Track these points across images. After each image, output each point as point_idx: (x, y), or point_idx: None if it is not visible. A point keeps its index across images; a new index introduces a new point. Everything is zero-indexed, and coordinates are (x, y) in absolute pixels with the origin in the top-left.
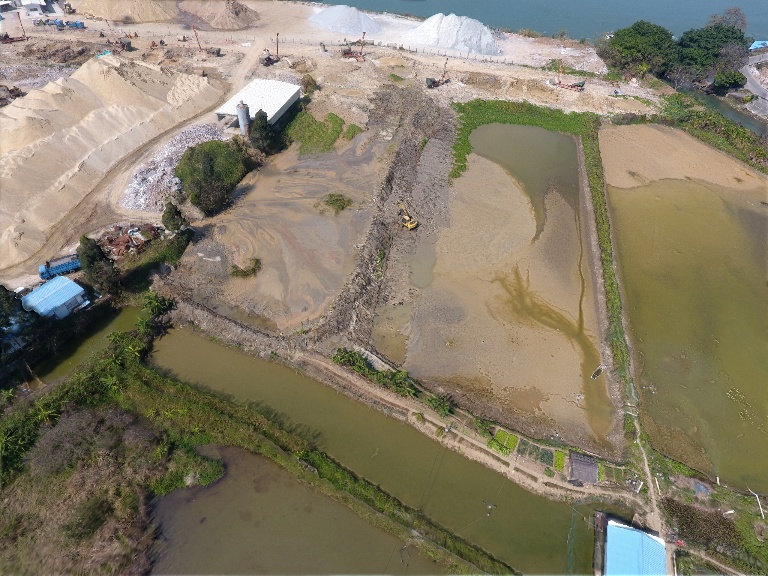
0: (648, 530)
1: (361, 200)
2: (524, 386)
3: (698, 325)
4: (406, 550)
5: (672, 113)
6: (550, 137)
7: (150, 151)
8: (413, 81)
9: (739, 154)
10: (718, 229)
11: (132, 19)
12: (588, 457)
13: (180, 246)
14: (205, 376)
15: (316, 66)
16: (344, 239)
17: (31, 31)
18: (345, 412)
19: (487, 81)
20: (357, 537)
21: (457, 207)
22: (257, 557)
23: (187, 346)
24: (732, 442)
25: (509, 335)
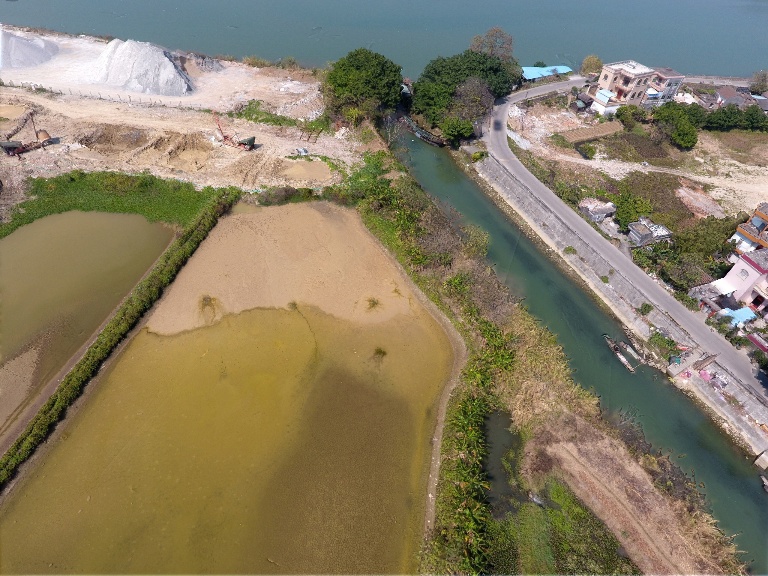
0: None
1: None
2: None
3: None
4: None
5: (354, 184)
6: (141, 233)
7: None
8: None
9: (399, 255)
10: (255, 420)
11: None
12: None
13: None
14: None
15: None
16: None
17: None
18: None
19: (126, 138)
20: None
21: None
22: None
23: None
24: None
25: None
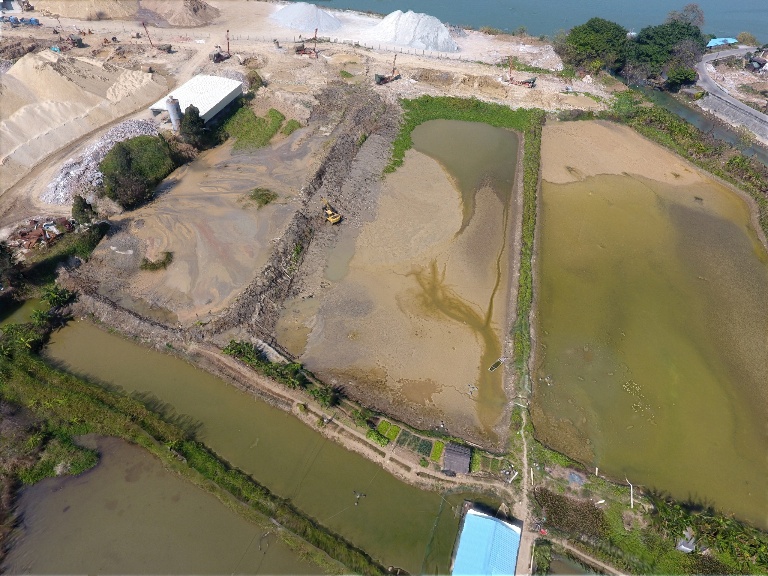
0: (513, 519)
1: (287, 195)
2: (419, 378)
3: (607, 318)
4: (266, 538)
5: (620, 109)
6: (494, 133)
7: (81, 146)
8: (363, 77)
9: (680, 150)
10: (646, 224)
11: (89, 16)
12: (463, 447)
13: (92, 239)
14: (99, 368)
15: (267, 63)
16: (262, 233)
17: None
18: (231, 403)
19: (439, 78)
20: (219, 526)
21: (385, 202)
22: (117, 545)
23: (84, 338)
24: (621, 433)
25: (414, 328)
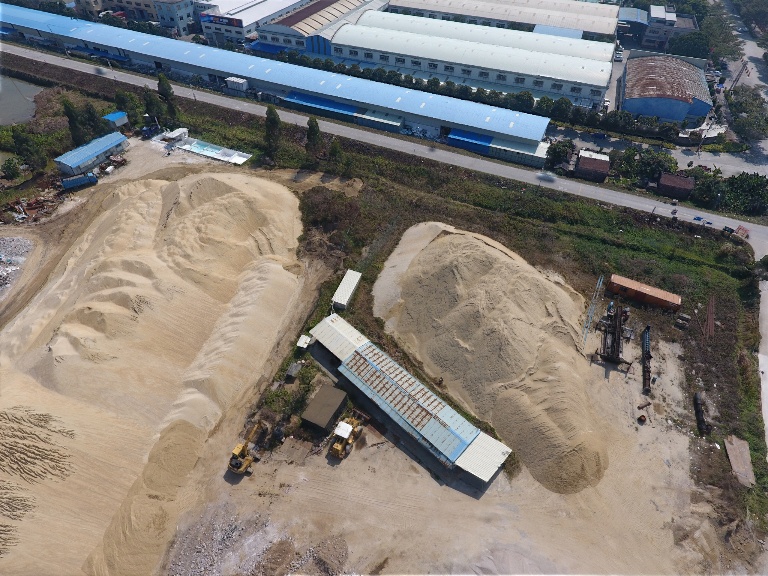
0: None
1: None
2: None
3: None
4: None
5: None
6: None
7: None
8: None
9: None
10: None
11: None
12: None
13: None
14: None
15: None
16: None
17: None
18: None
19: None
20: None
21: None
22: None
23: None
24: None
25: None
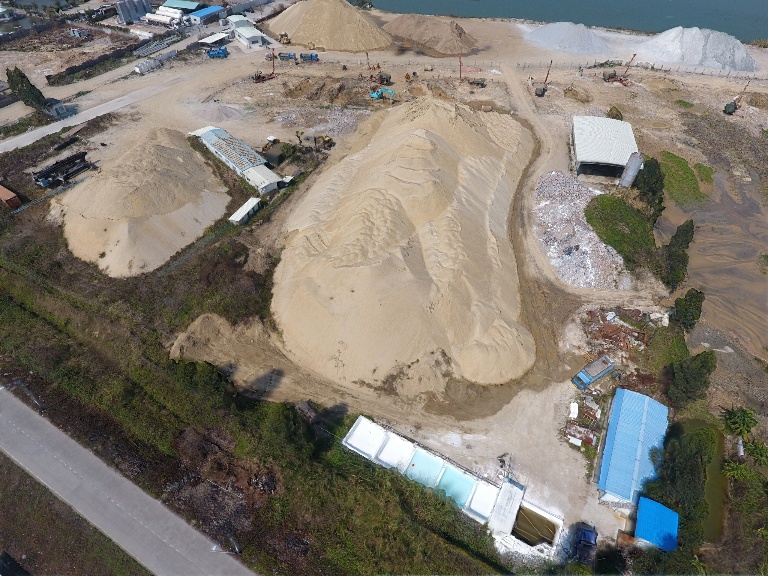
0: None
1: None
2: None
3: None
4: None
5: None
6: None
7: (527, 209)
8: (704, 107)
9: None
10: None
11: (356, 48)
12: None
13: (683, 335)
14: None
15: (590, 94)
16: None
17: (269, 67)
18: None
19: None
20: None
21: None
22: None
23: None
24: None
25: None
